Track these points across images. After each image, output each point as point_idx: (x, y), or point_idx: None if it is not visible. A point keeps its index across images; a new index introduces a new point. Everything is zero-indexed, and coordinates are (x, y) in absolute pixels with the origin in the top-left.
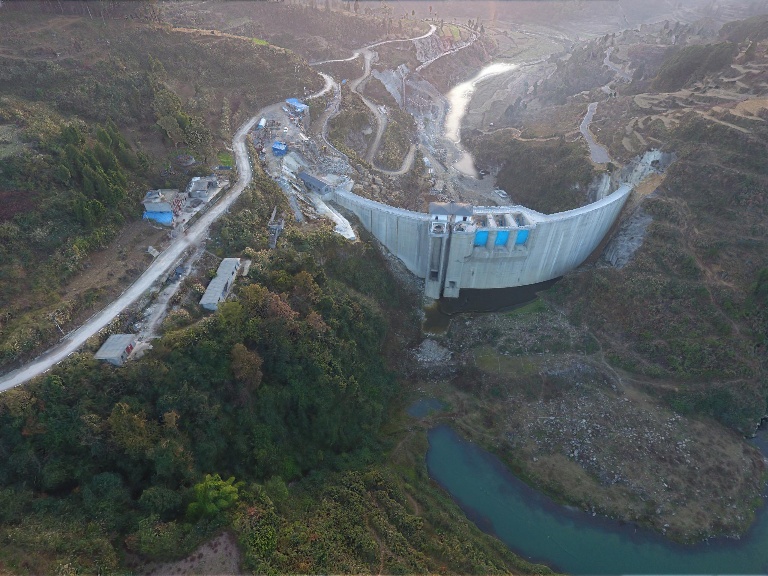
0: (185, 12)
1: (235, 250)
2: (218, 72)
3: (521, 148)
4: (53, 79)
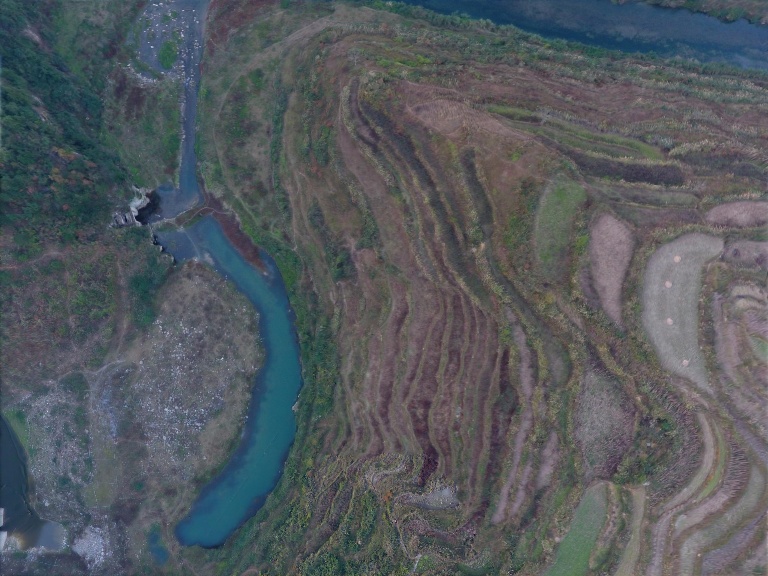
0: None
1: None
2: None
3: None
4: None
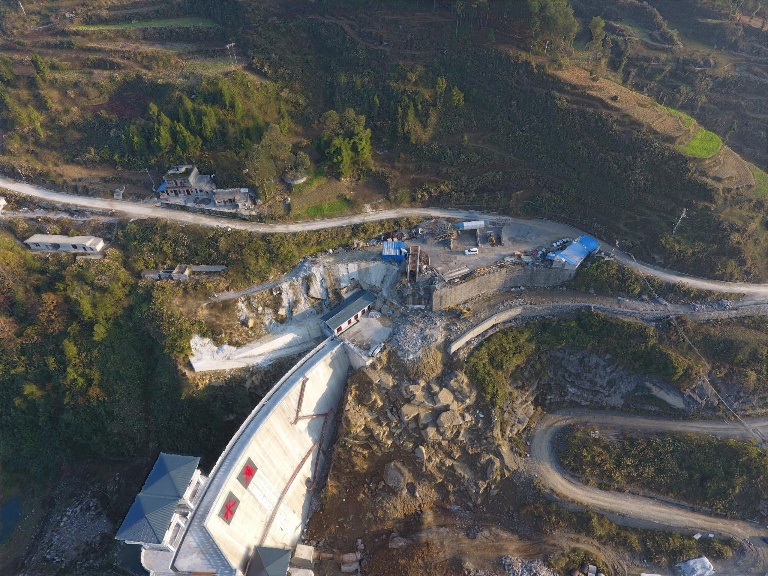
0: (715, 68)
1: (123, 245)
2: (546, 144)
3: None
4: (350, 61)
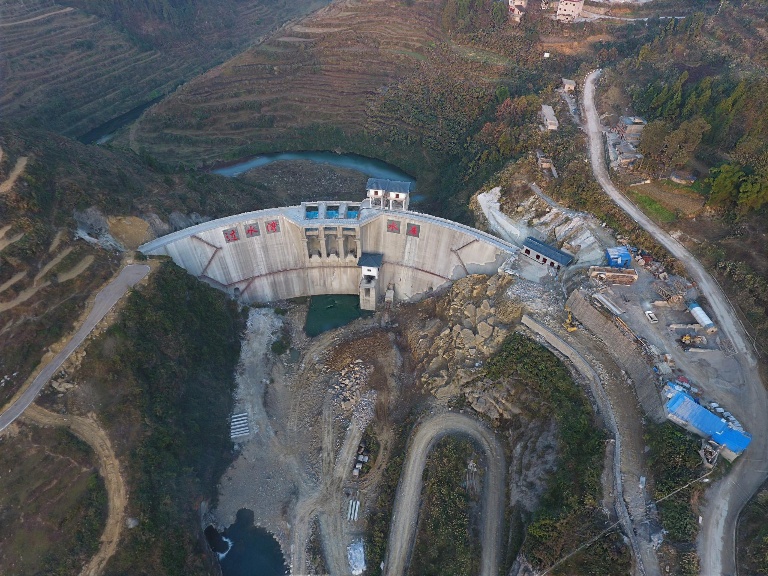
0: None
1: None
2: None
3: (161, 443)
4: None
